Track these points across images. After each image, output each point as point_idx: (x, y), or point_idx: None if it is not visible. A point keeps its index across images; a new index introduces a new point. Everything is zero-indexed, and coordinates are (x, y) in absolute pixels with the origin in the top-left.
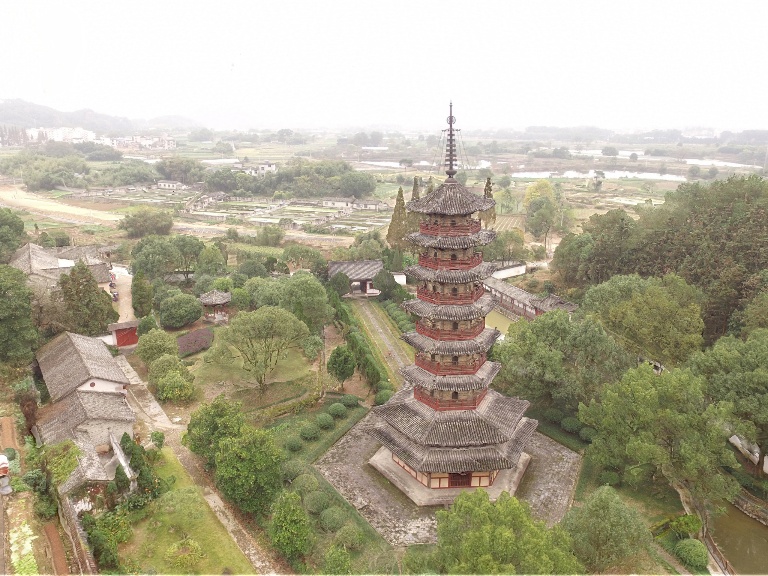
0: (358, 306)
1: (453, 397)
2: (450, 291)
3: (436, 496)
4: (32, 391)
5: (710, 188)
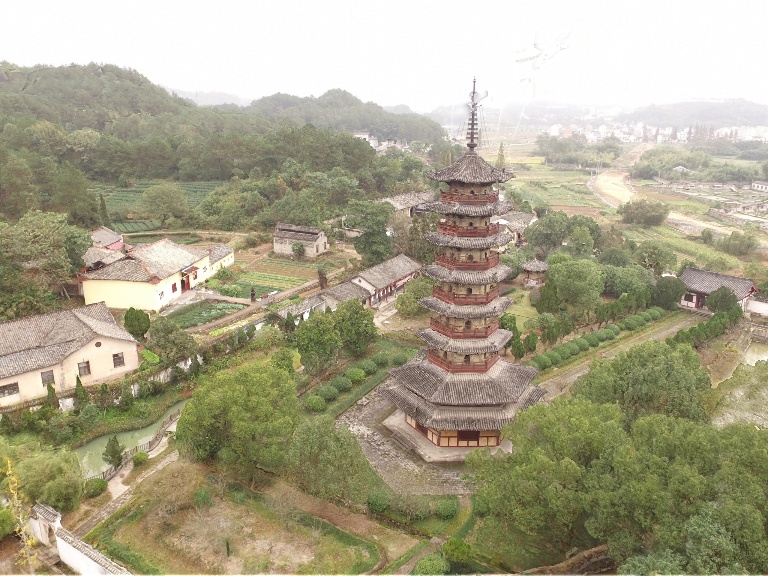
0: (682, 319)
1: (445, 355)
2: (450, 255)
3: (400, 427)
4: None
5: None
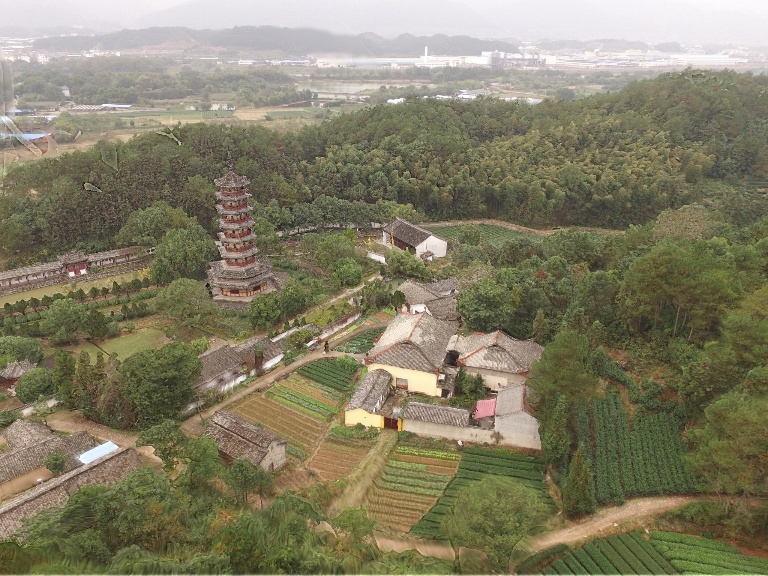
0: None
1: None
2: None
3: None
4: (256, 351)
5: (46, 164)
